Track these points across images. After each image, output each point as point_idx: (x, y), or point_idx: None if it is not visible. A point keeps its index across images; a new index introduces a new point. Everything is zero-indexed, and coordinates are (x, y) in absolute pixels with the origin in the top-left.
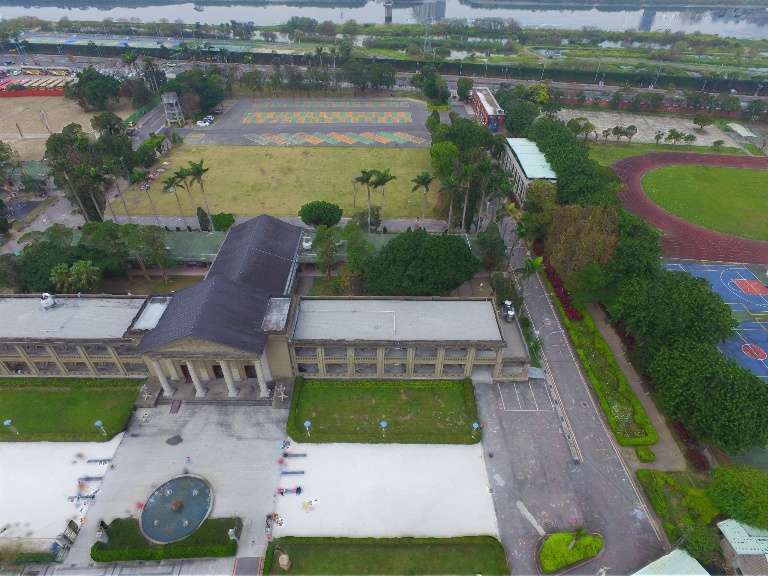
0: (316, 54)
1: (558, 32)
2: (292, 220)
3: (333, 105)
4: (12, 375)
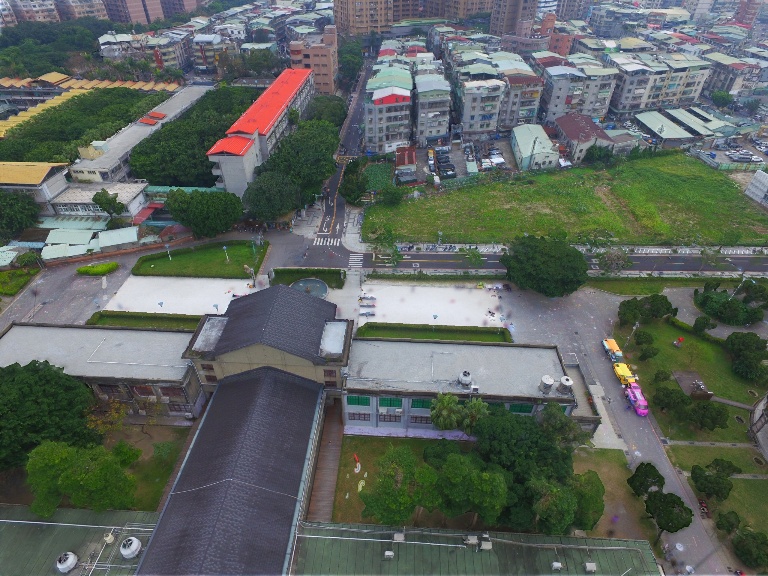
0: None
1: None
2: None
3: None
4: None
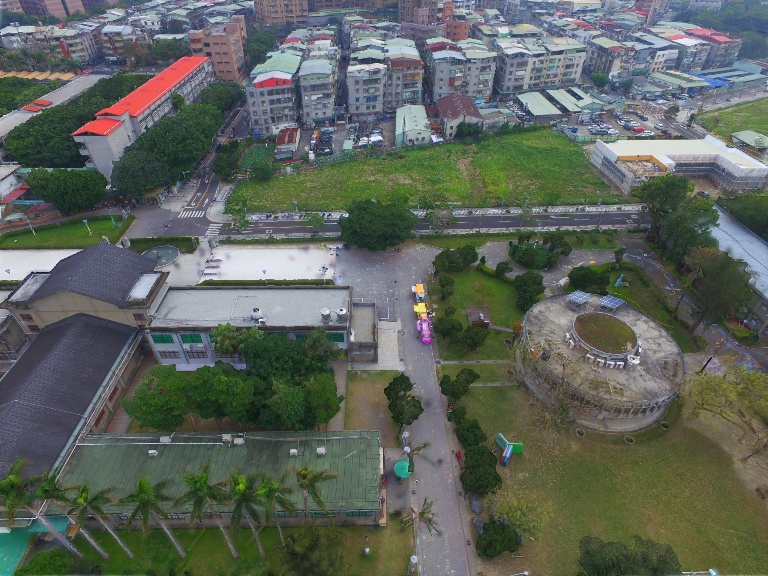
0: None
1: None
2: None
3: None
4: None
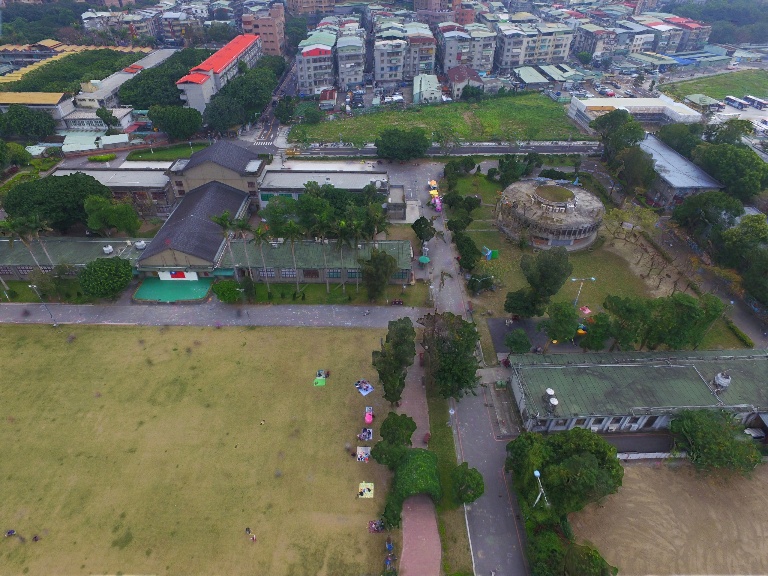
0: None
1: None
2: (144, 319)
3: None
4: None
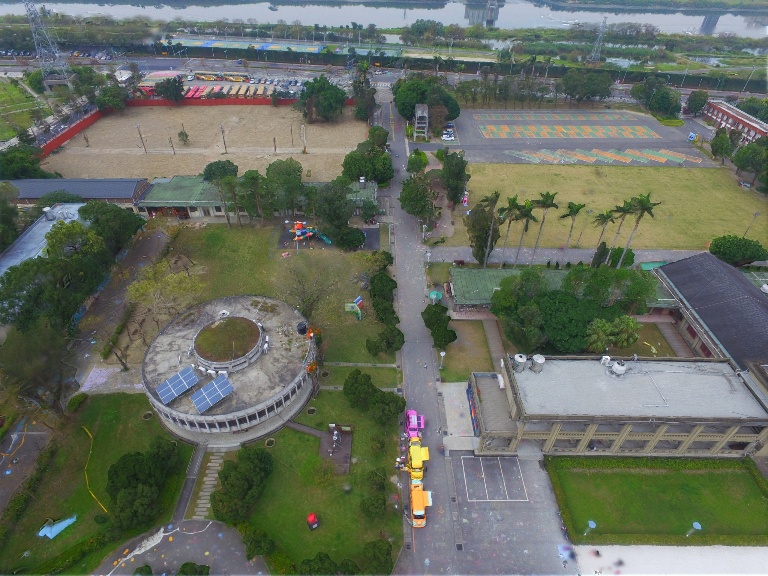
0: (531, 63)
1: (692, 38)
2: (672, 254)
3: (557, 118)
4: (583, 453)
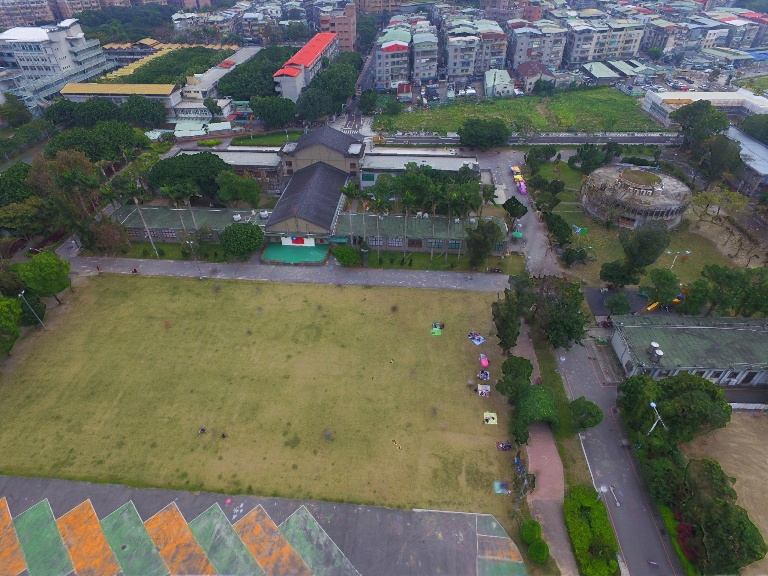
0: None
1: None
2: (274, 276)
3: None
4: None
